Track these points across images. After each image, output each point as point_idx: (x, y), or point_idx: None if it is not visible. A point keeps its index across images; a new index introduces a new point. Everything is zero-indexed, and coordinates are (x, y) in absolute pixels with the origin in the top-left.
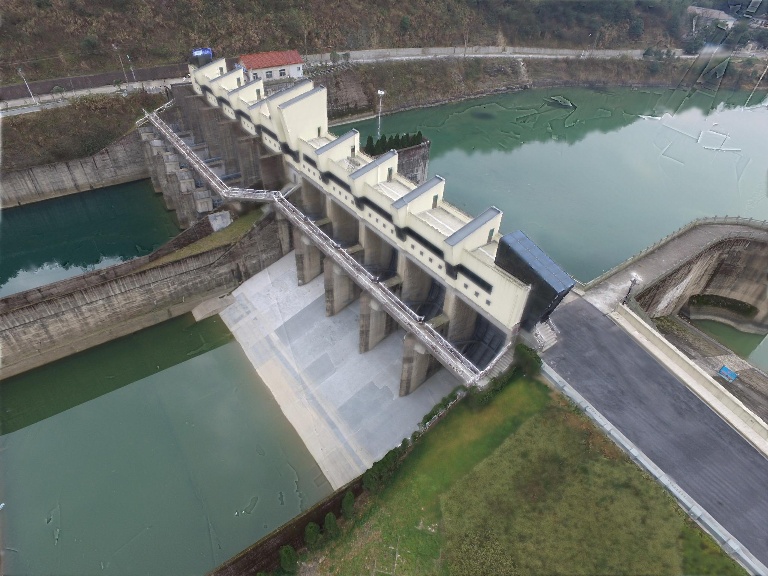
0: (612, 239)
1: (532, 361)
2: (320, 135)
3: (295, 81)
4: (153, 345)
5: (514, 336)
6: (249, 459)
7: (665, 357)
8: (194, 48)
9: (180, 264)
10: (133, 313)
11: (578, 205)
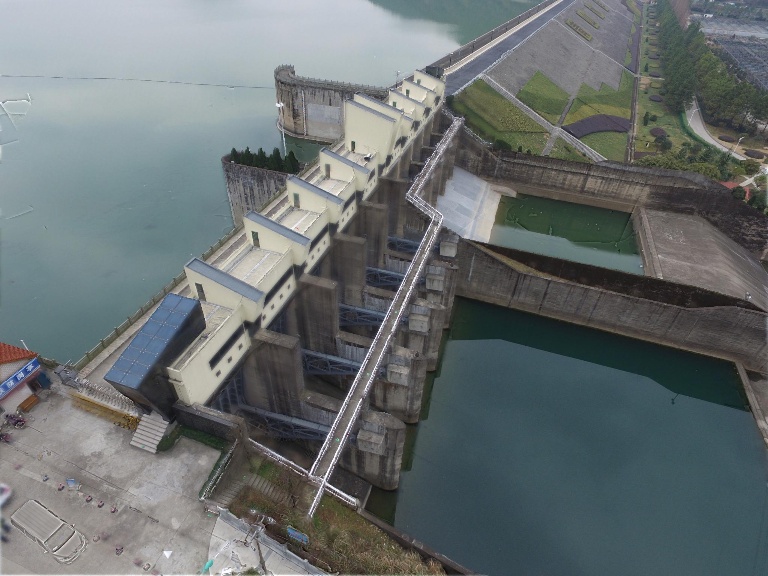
0: (230, 149)
1: None
2: None
3: None
4: None
5: None
6: None
7: None
8: None
9: None
10: None
11: (179, 162)
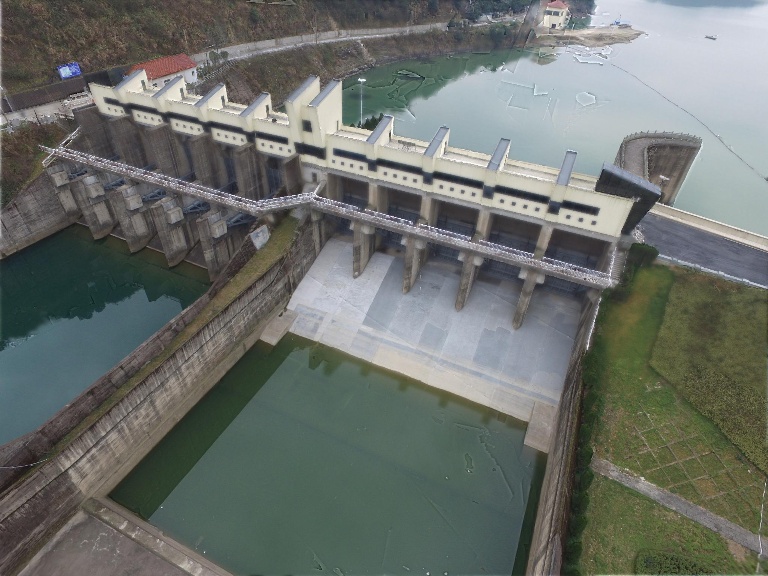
0: None
1: (651, 251)
2: (337, 128)
3: (195, 87)
4: (232, 388)
5: (617, 242)
6: (424, 434)
7: (699, 226)
8: (56, 65)
9: (251, 290)
10: (219, 358)
11: None
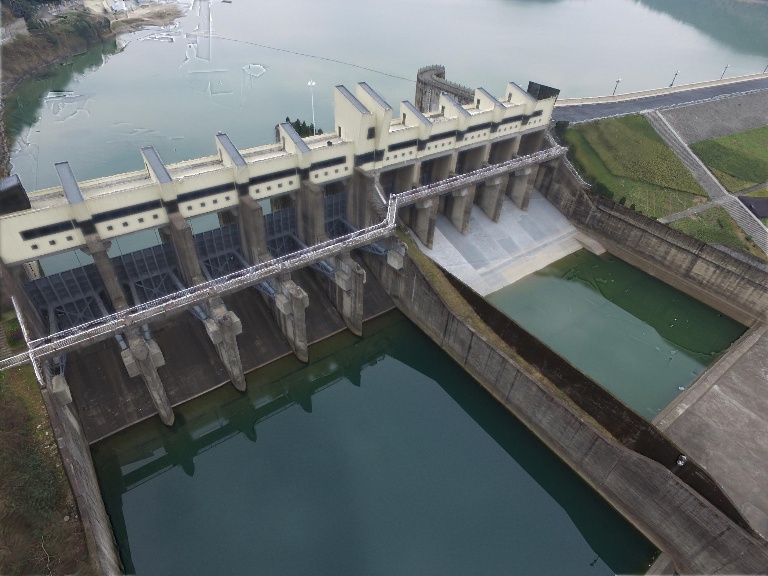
0: None
1: None
2: None
3: None
4: None
5: None
6: None
7: None
8: None
9: None
10: None
11: None
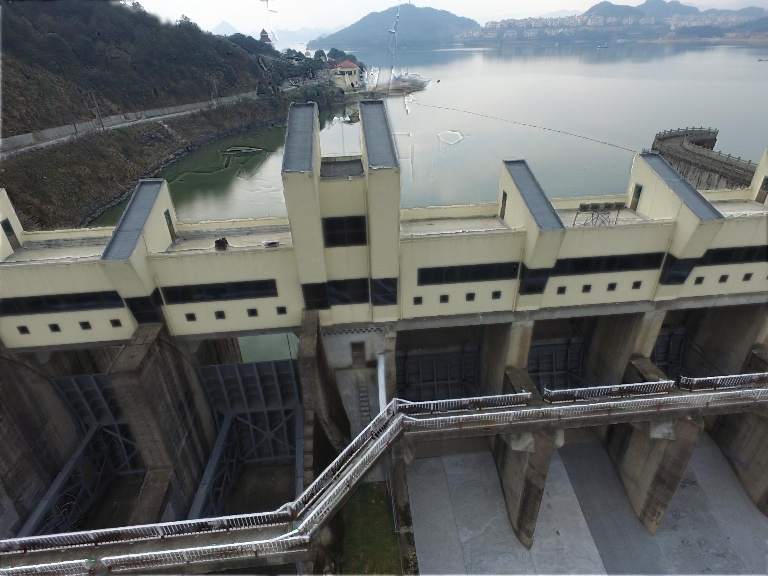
0: None
1: None
2: None
3: None
4: None
5: None
6: None
7: None
8: None
9: None
10: None
11: None
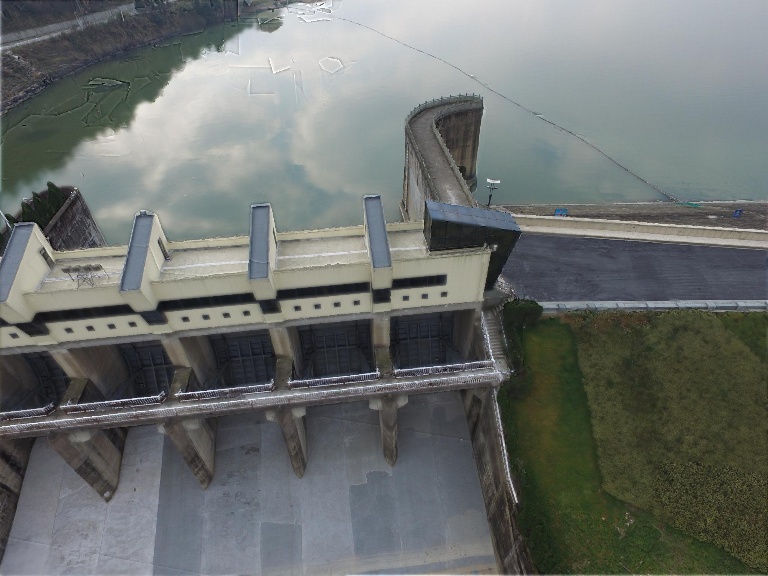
0: (321, 181)
1: (533, 309)
2: None
3: None
4: None
5: None
6: None
7: (551, 229)
8: None
9: None
10: None
11: (260, 170)
